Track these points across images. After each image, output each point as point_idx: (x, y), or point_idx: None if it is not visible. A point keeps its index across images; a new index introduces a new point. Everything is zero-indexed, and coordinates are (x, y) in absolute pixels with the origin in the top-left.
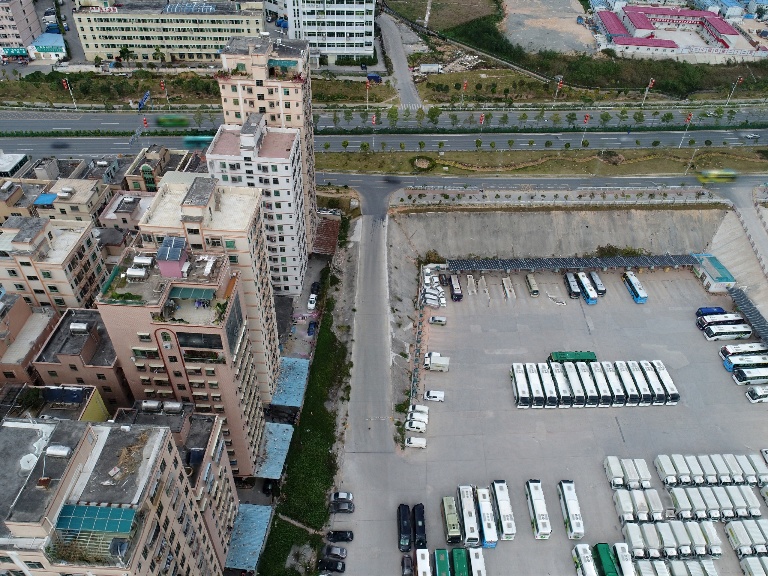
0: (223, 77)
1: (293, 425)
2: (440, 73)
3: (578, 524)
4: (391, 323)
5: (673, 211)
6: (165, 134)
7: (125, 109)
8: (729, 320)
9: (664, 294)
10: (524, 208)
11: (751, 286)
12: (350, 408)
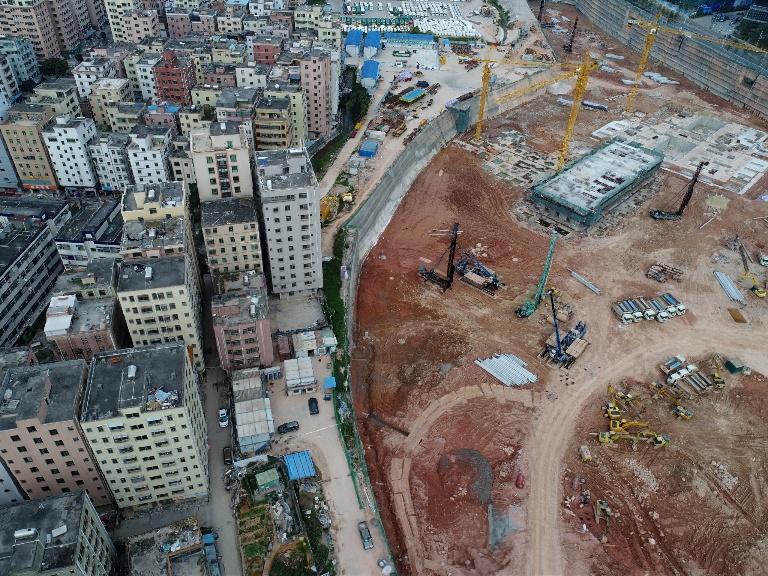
0: None
1: None
2: None
3: (389, 5)
4: None
5: None
6: None
7: None
8: None
9: None
10: None
11: None
12: None
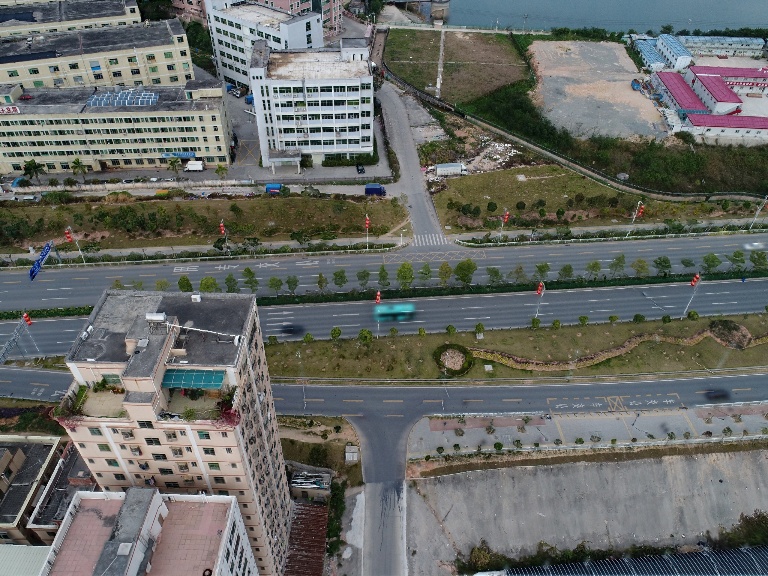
0: (66, 419)
1: None
2: (463, 175)
3: None
4: None
5: None
6: (70, 314)
7: (20, 265)
8: None
9: None
10: (620, 454)
11: None
12: None
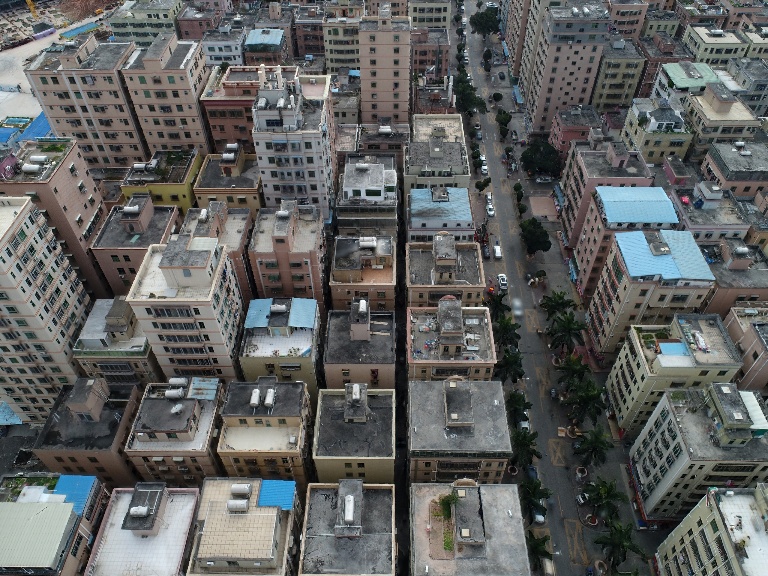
0: None
1: None
2: None
3: None
4: None
5: None
6: None
7: None
8: None
9: None
10: None
11: None
12: None
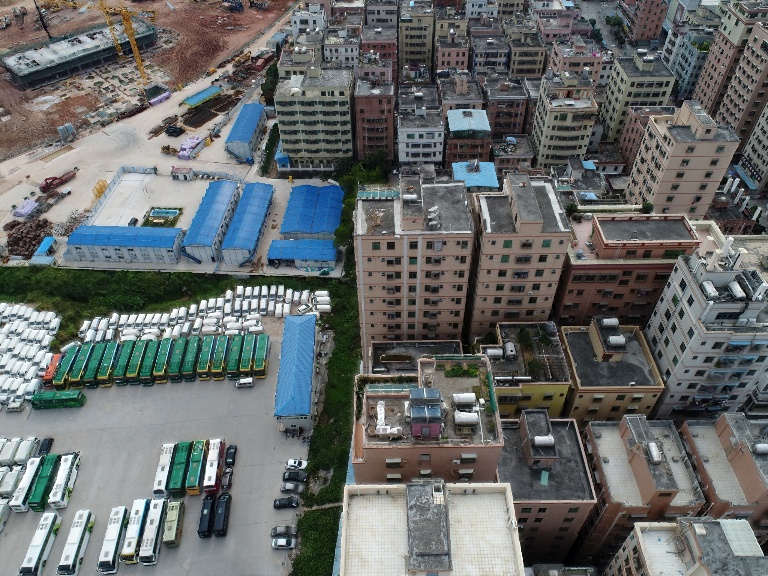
0: None
1: None
2: None
3: (45, 520)
4: None
5: None
6: None
7: None
8: None
9: None
10: None
11: None
12: None
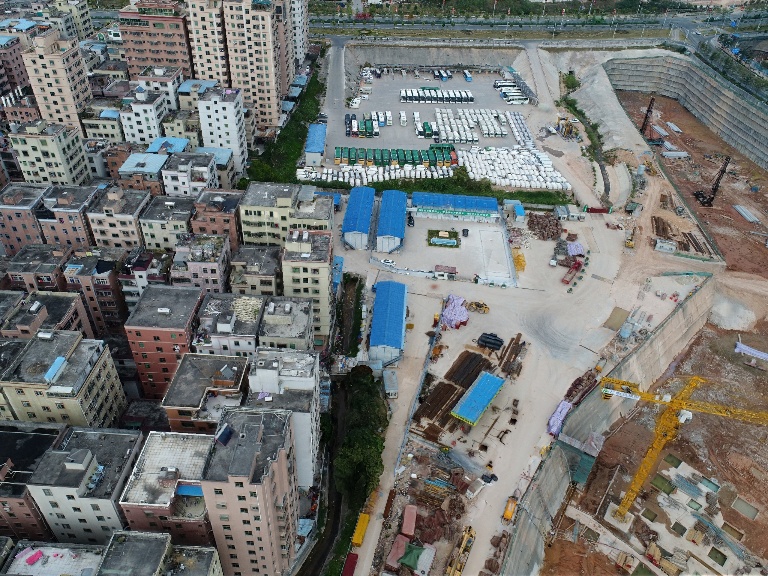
0: None
1: (302, 88)
2: None
3: (417, 118)
4: (345, 78)
5: (493, 50)
6: None
7: None
8: (507, 82)
9: (482, 79)
10: (416, 46)
11: (524, 75)
12: (326, 99)
